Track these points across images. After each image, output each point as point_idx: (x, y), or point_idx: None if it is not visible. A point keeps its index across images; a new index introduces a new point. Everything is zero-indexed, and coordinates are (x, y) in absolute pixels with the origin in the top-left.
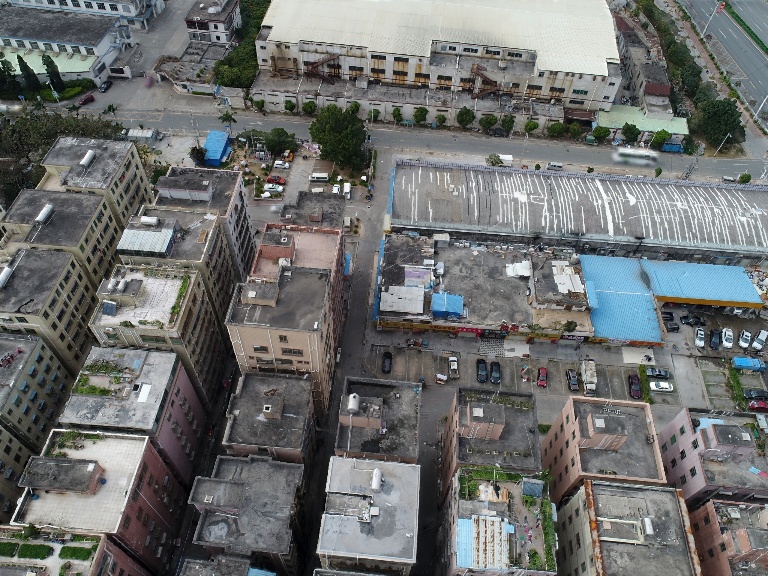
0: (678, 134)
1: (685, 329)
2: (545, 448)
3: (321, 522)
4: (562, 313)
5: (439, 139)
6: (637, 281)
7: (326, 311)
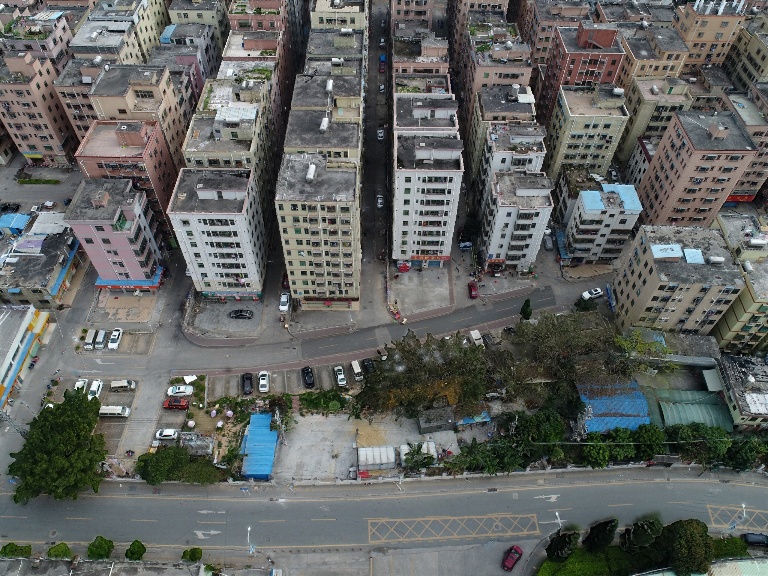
0: None
1: None
2: None
3: None
4: None
5: None
6: None
7: None
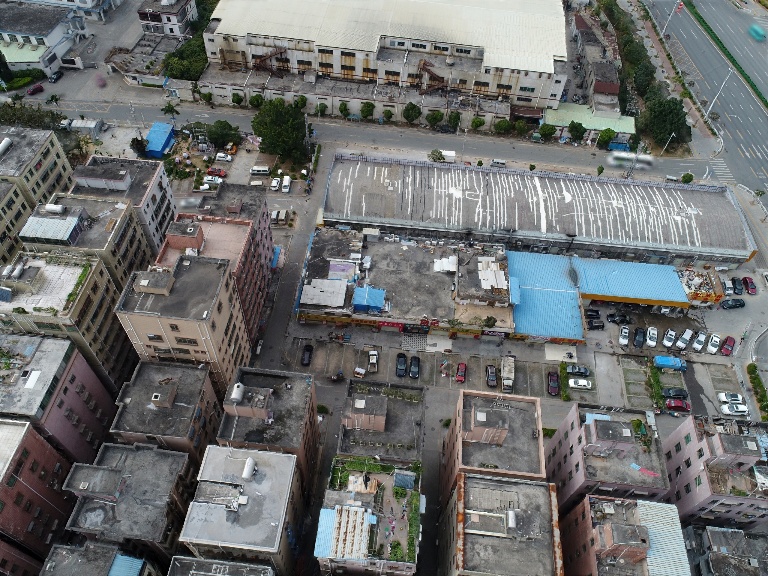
0: (624, 133)
1: (611, 327)
2: (447, 442)
3: (188, 510)
4: (485, 309)
5: (385, 134)
6: (565, 278)
7: (223, 301)
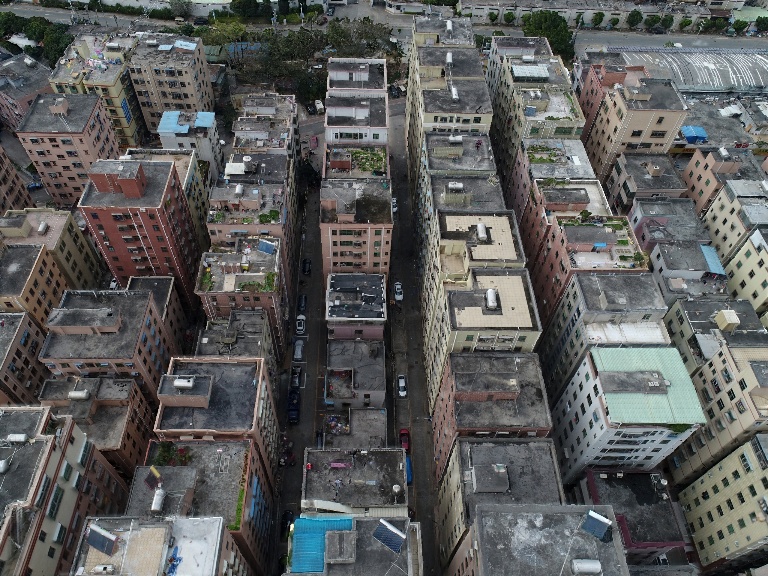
0: None
1: None
2: None
3: (744, 210)
4: None
5: (614, 37)
6: None
7: None
